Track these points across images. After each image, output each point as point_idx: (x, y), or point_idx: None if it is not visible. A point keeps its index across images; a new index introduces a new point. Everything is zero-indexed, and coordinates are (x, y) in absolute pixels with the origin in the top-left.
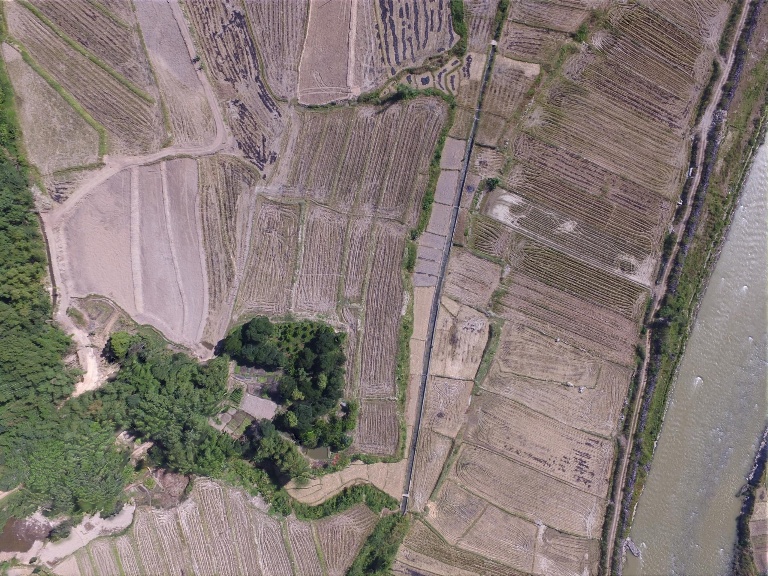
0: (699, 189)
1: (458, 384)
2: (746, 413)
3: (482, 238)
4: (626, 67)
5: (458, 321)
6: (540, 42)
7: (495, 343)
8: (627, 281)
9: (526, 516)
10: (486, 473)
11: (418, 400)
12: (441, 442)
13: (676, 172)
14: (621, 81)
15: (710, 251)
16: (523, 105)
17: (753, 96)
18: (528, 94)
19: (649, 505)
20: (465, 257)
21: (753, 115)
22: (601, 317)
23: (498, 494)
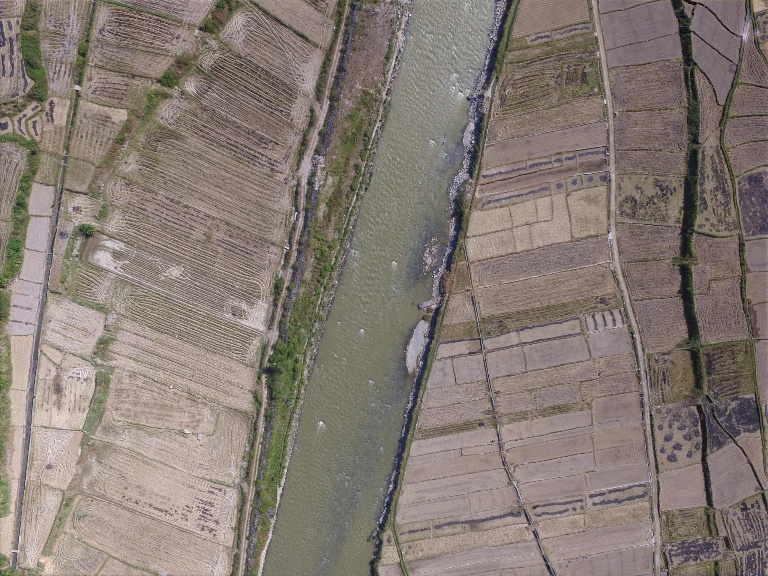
0: (301, 234)
1: (66, 434)
2: (371, 456)
3: (84, 285)
4: (222, 112)
5: (62, 370)
6: (126, 87)
7: (103, 392)
8: (239, 326)
9: (150, 568)
10: (105, 525)
11: (24, 452)
12: (52, 495)
13: (281, 217)
14: (218, 126)
15: (321, 295)
16: (112, 150)
17: (350, 142)
18: (116, 139)
19: (279, 552)
20: (66, 304)
21: (353, 160)
22: (215, 363)
23: (119, 546)
